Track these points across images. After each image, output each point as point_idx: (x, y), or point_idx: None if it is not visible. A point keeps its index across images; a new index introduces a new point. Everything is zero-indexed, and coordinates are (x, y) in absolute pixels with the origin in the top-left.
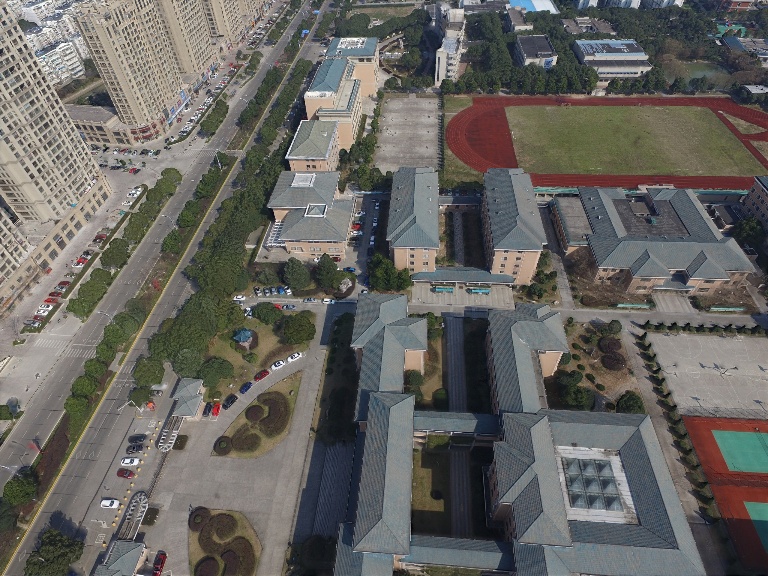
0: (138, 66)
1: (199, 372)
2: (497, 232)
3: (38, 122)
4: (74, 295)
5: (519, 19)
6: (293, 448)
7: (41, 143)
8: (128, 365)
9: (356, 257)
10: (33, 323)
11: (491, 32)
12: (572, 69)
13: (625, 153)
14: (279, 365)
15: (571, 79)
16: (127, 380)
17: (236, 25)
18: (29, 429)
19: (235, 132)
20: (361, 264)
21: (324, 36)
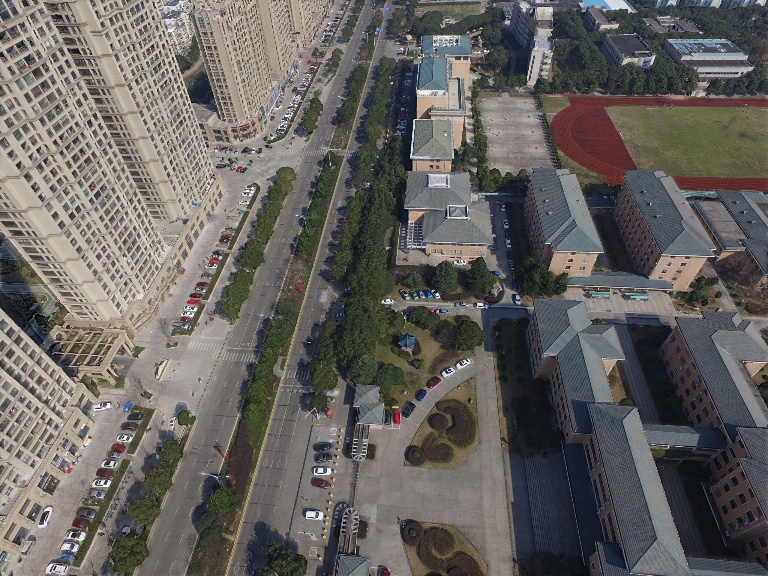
0: (244, 63)
1: (375, 378)
2: (661, 237)
3: (176, 119)
4: (214, 296)
5: (602, 18)
6: (489, 459)
7: (177, 141)
8: (291, 370)
9: (496, 260)
10: (183, 325)
11: (575, 31)
12: (672, 69)
13: (745, 155)
14: (450, 372)
15: (672, 79)
16: (294, 385)
17: (309, 22)
18: (206, 435)
19: (333, 131)
20: (503, 268)
21: (397, 34)
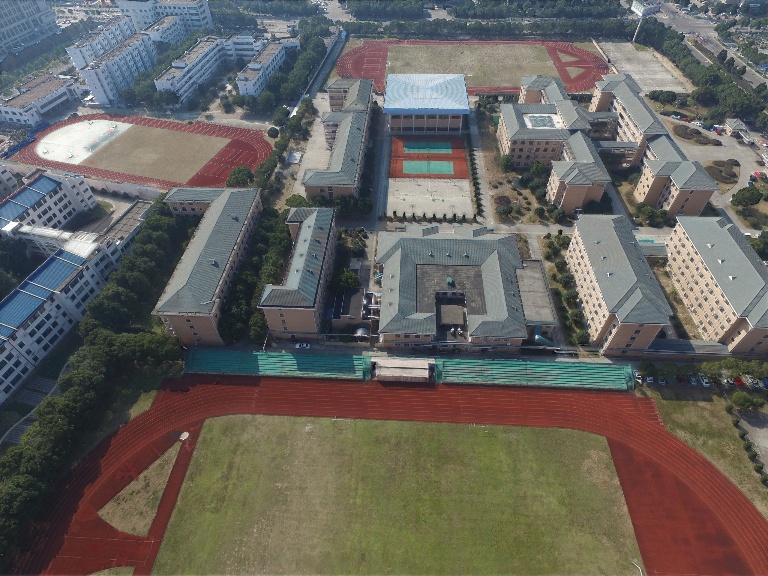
0: None
1: None
2: (627, 226)
3: None
4: None
5: None
6: None
7: None
8: None
9: None
10: None
11: None
12: None
13: (411, 491)
14: None
15: None
16: None
17: None
18: None
19: None
20: None
21: None
